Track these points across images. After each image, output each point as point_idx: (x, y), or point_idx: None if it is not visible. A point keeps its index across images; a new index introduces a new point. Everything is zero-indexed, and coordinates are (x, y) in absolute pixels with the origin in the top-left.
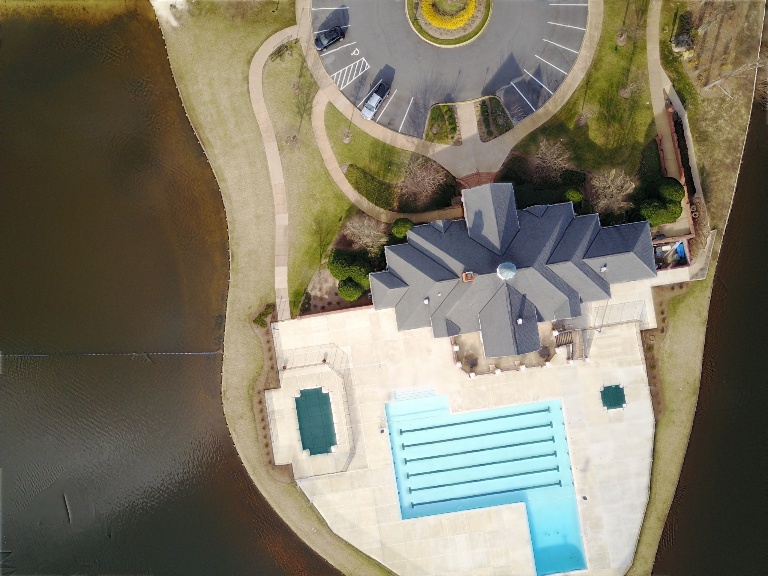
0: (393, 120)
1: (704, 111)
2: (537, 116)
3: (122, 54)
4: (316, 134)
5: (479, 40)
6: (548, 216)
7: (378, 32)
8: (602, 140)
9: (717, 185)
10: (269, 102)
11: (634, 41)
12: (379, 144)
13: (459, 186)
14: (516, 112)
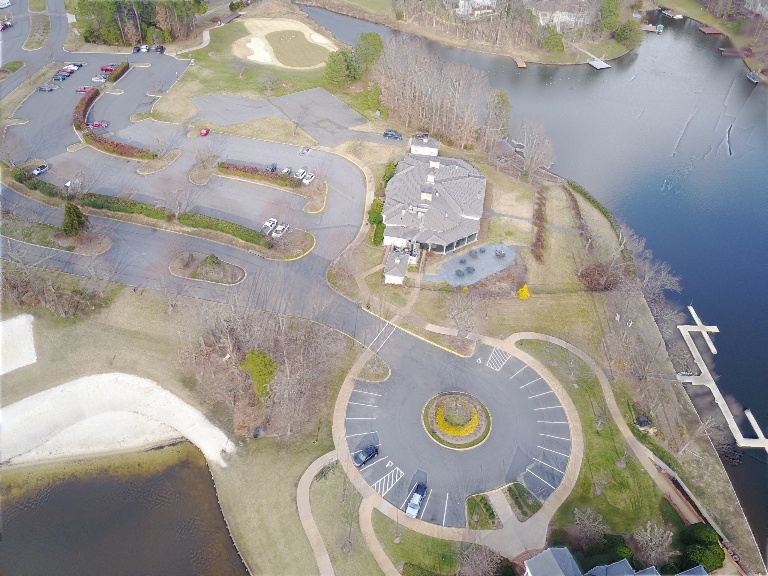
0: (435, 515)
1: (688, 471)
2: (559, 493)
3: (171, 498)
4: (367, 539)
5: (489, 441)
6: (612, 575)
7: (405, 446)
8: (622, 504)
9: (735, 531)
10: (317, 517)
11: (608, 426)
12: (428, 539)
13: (514, 566)
14: (540, 492)
